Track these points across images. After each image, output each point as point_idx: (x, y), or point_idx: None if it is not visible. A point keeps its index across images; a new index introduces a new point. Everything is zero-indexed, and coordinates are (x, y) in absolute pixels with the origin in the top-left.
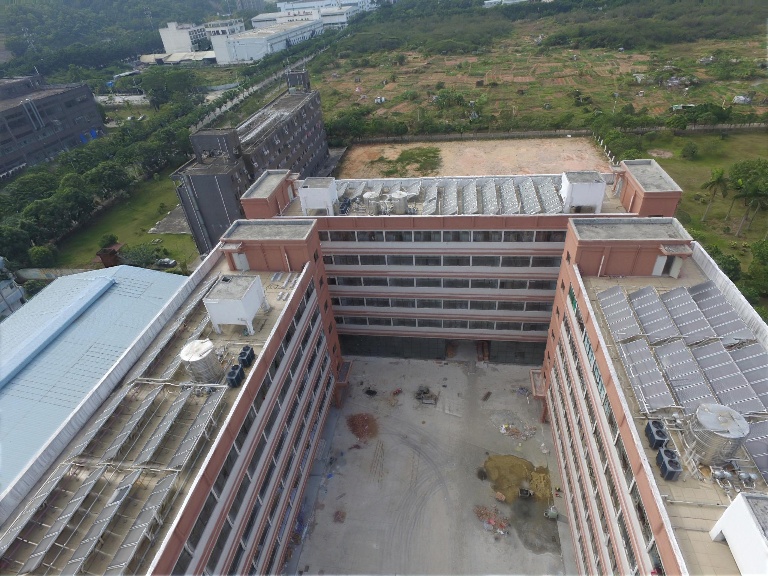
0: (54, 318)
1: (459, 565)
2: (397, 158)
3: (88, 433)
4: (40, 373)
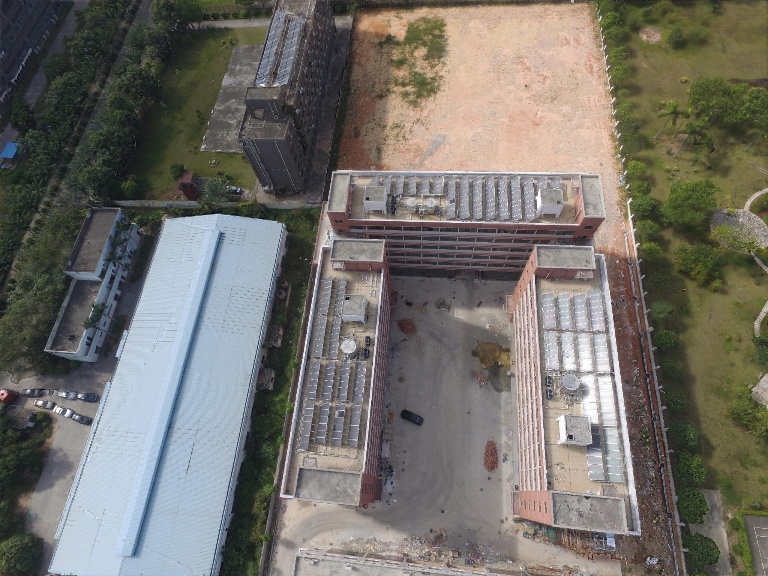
0: (198, 270)
1: (462, 399)
2: (404, 37)
3: (311, 386)
4: (212, 312)
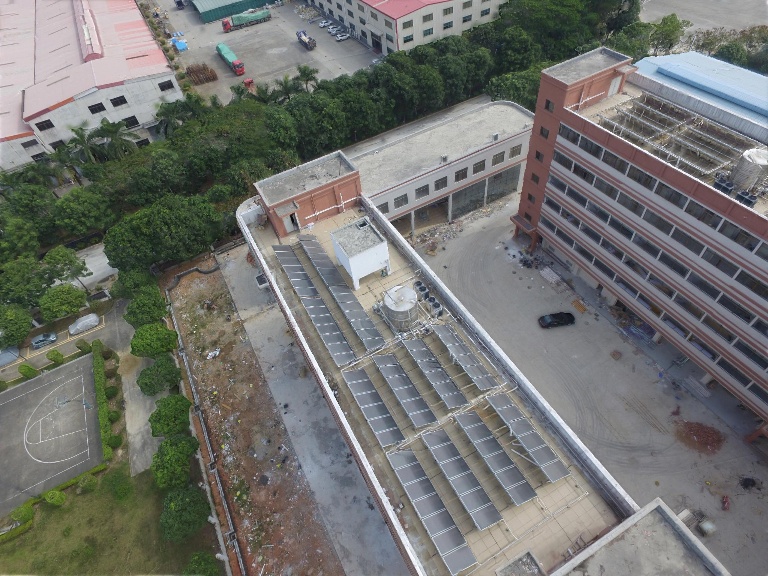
0: None
1: None
2: None
3: None
4: None
